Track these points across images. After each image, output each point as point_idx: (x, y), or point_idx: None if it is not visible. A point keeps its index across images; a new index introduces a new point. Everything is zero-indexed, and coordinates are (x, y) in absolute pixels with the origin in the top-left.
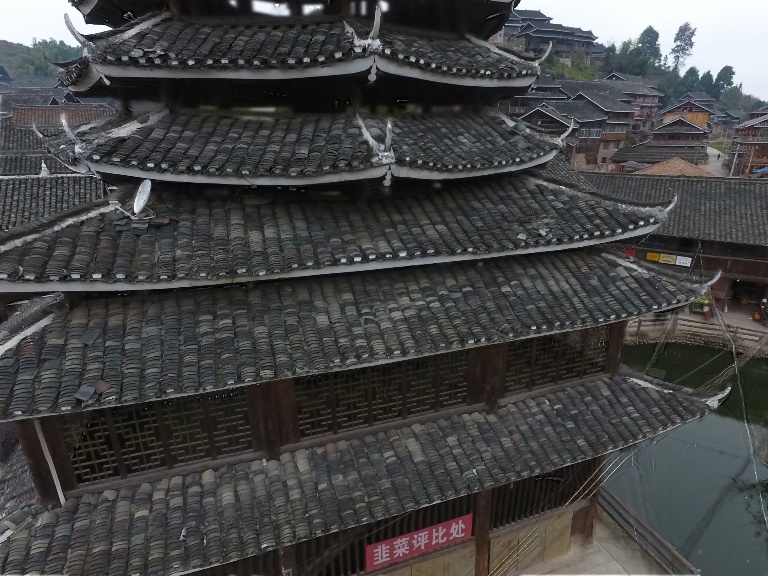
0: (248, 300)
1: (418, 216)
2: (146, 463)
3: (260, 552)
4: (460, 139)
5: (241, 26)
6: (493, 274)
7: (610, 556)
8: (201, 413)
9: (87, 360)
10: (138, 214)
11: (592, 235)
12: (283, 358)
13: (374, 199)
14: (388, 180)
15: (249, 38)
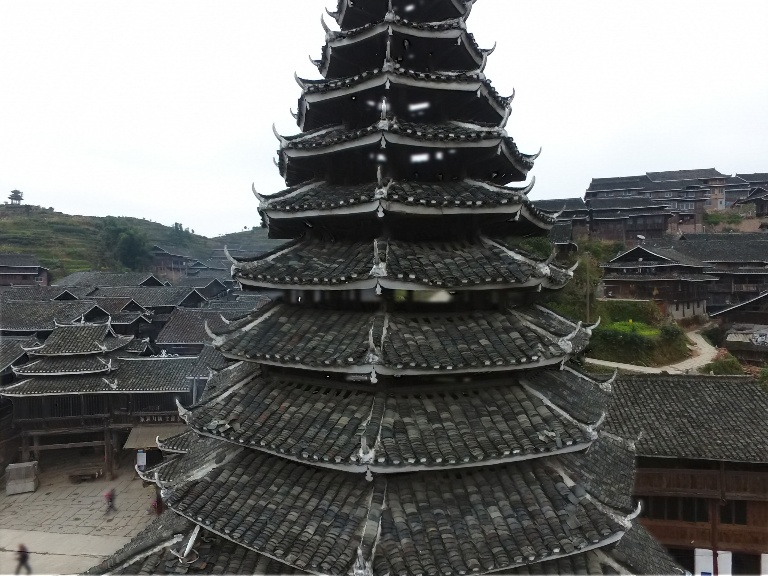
0: None
1: None
2: None
3: None
4: (490, 511)
5: (305, 385)
6: None
7: None
8: None
9: None
10: (184, 558)
11: None
12: None
13: None
14: None
15: (299, 408)
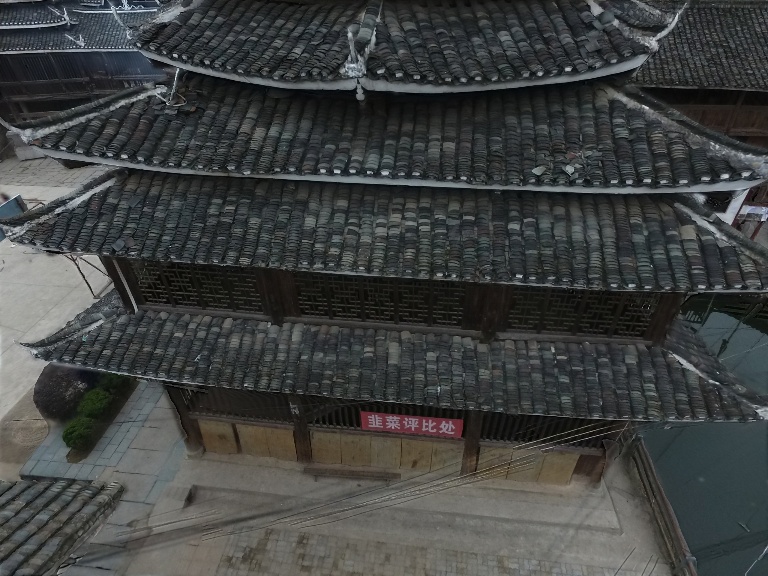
0: (254, 191)
1: (431, 128)
2: (187, 301)
3: (244, 388)
4: (500, 36)
5: None
6: (508, 206)
7: (611, 506)
8: (221, 275)
9: (129, 219)
10: (170, 101)
11: (640, 182)
12: (262, 250)
13: (394, 102)
14: (360, 94)
15: None
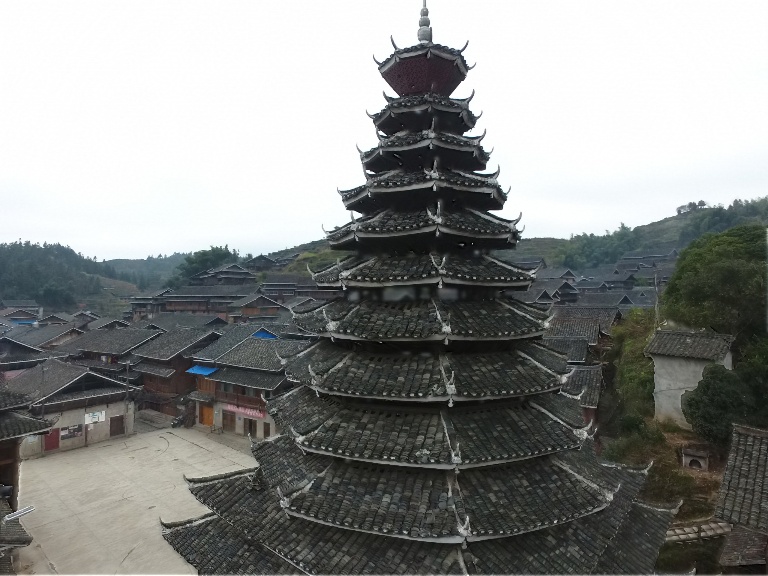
0: None
1: (347, 542)
2: None
3: None
4: (384, 497)
5: None
6: None
7: None
8: None
9: None
10: None
11: None
12: None
13: None
14: (288, 516)
15: None
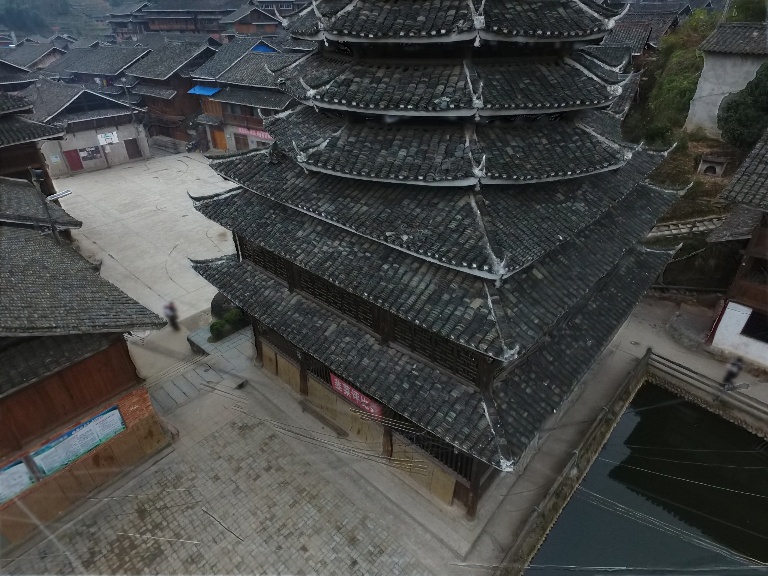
0: None
1: (365, 196)
2: (260, 264)
3: None
4: (400, 151)
5: None
6: None
7: (472, 540)
8: None
9: None
10: None
11: None
12: (272, 241)
13: None
14: (306, 170)
15: None
